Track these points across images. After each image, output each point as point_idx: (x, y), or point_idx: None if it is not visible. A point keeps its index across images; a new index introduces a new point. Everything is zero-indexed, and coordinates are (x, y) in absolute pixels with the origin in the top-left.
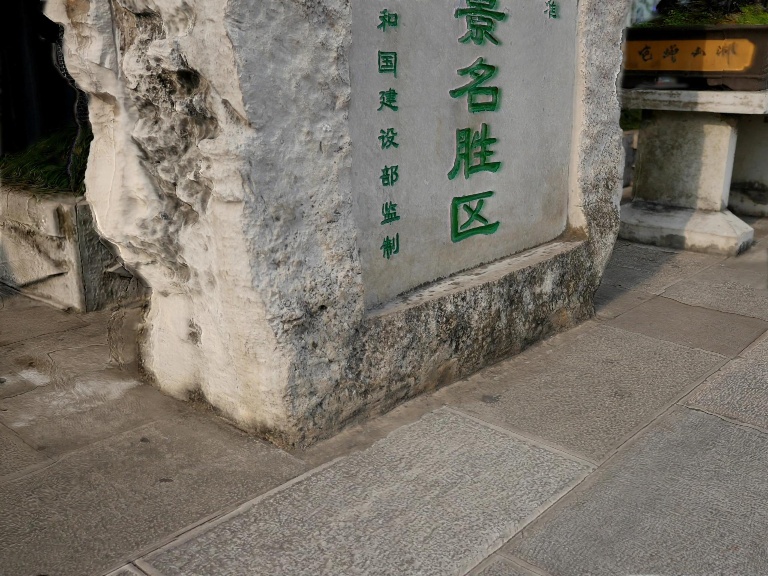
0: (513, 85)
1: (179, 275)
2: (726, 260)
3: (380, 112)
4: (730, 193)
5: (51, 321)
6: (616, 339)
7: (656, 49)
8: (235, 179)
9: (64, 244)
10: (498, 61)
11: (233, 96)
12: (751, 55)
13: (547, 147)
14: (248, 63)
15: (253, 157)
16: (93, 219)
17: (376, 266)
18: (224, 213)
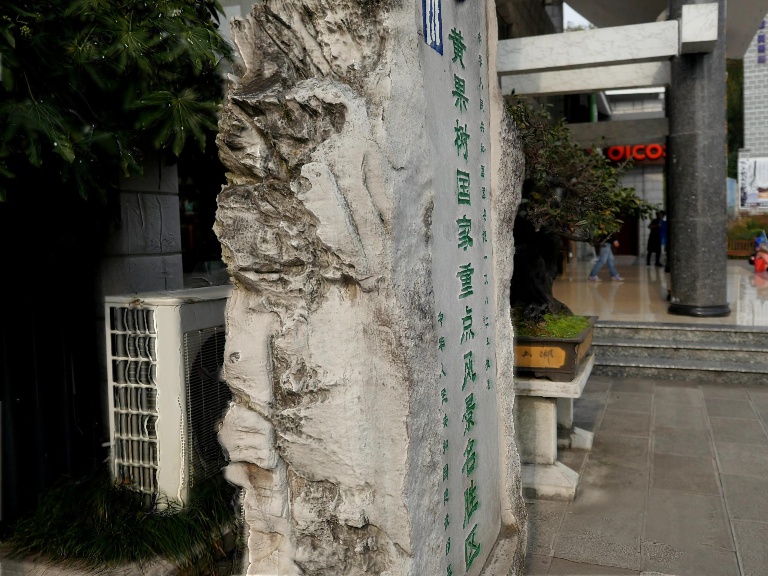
0: (479, 445)
1: None
2: (569, 506)
3: (444, 507)
4: None
5: None
6: None
7: None
8: None
9: None
10: (474, 435)
11: (402, 541)
12: (564, 359)
13: (491, 475)
14: (412, 519)
15: None
16: None
17: None
18: None
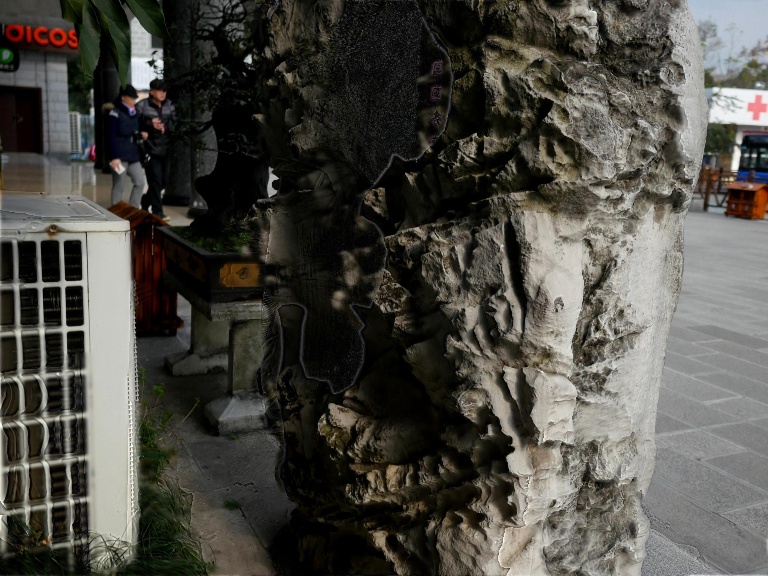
0: None
1: None
2: None
3: None
4: None
5: None
6: None
7: (252, 270)
8: None
9: None
10: None
11: (644, 486)
12: None
13: None
14: None
15: None
16: None
17: None
18: (635, 570)
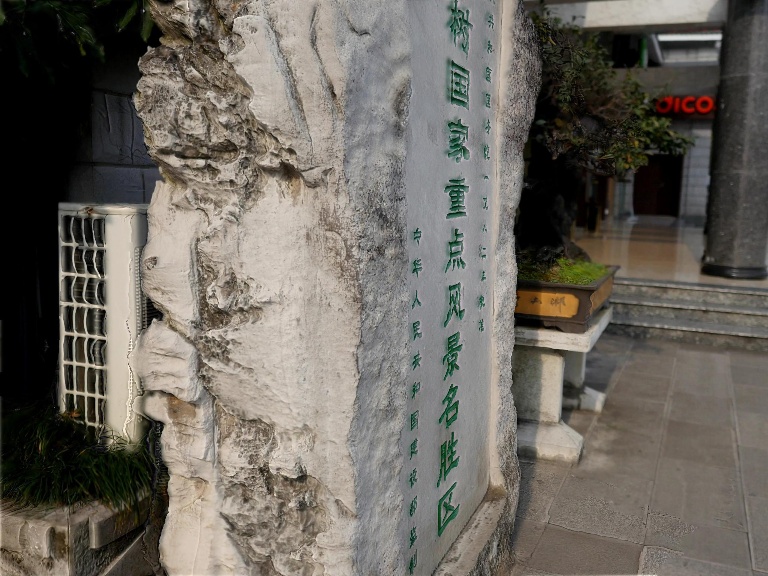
0: (465, 393)
1: None
2: (572, 469)
3: (411, 460)
4: None
5: None
6: None
7: None
8: (346, 563)
9: (51, 564)
10: (459, 381)
11: (346, 497)
12: (577, 307)
13: (480, 429)
14: (360, 472)
15: (359, 542)
16: None
17: None
18: None
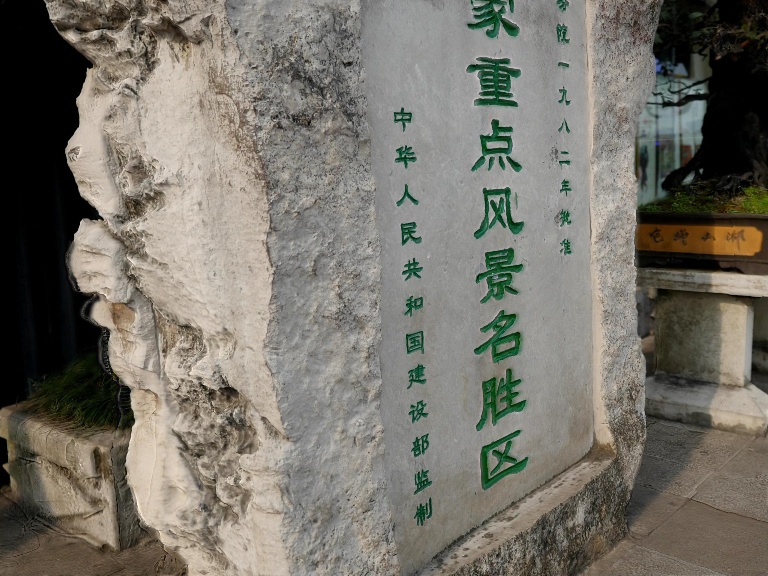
0: (534, 326)
1: (218, 561)
2: (755, 442)
3: (410, 390)
4: (752, 367)
5: (86, 564)
6: (653, 567)
7: (667, 232)
8: (274, 492)
9: (100, 484)
10: (519, 308)
11: (272, 415)
12: (761, 242)
13: (570, 373)
14: (286, 386)
15: (291, 470)
16: (134, 502)
17: (411, 536)
18: (264, 522)
